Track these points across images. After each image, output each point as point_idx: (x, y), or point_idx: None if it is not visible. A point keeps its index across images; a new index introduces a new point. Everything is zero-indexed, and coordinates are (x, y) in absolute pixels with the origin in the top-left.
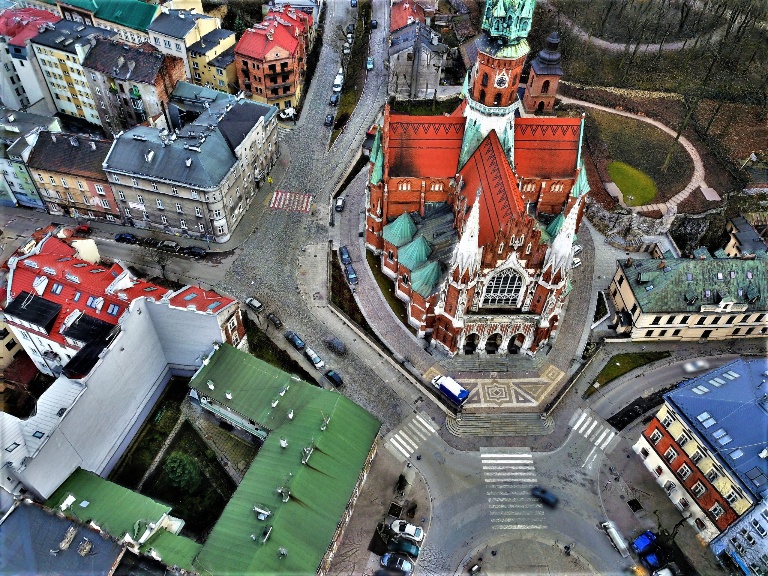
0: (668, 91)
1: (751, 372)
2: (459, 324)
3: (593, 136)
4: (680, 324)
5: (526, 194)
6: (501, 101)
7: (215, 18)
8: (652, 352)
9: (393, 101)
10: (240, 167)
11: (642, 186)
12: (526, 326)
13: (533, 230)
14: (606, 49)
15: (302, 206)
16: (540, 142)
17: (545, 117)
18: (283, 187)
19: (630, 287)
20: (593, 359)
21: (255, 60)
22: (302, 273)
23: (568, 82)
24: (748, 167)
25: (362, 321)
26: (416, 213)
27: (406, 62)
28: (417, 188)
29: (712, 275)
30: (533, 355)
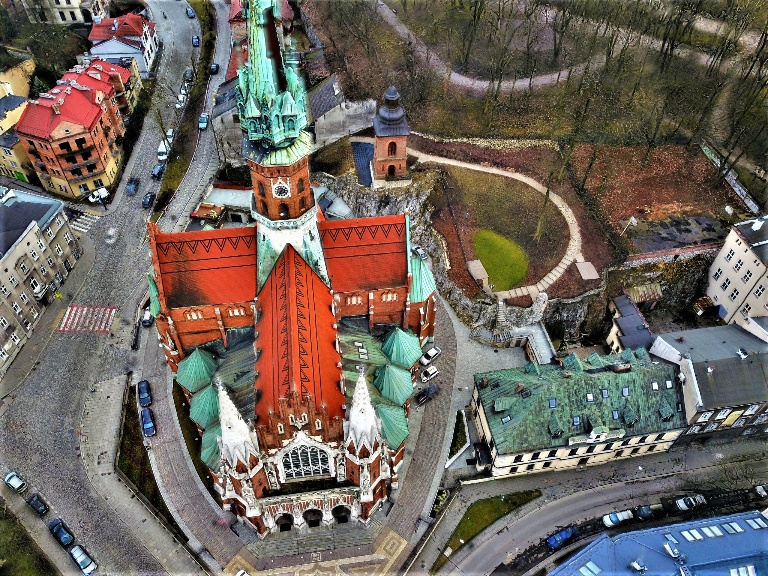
0: (540, 138)
1: (615, 561)
2: (253, 512)
3: (456, 200)
4: (548, 457)
5: (353, 307)
6: (288, 211)
7: (1, 84)
8: (519, 492)
9: (228, 168)
10: (0, 294)
11: (511, 262)
12: (346, 498)
13: (338, 381)
14: (470, 89)
15: (101, 324)
16: (357, 247)
17: (398, 182)
18: (80, 299)
19: (485, 416)
20: (446, 512)
21: (40, 140)
22: (88, 425)
23: (426, 135)
24: (631, 230)
25: (154, 493)
26: (219, 341)
27: (233, 124)
28: (211, 315)
29: (580, 397)
30: (366, 523)
